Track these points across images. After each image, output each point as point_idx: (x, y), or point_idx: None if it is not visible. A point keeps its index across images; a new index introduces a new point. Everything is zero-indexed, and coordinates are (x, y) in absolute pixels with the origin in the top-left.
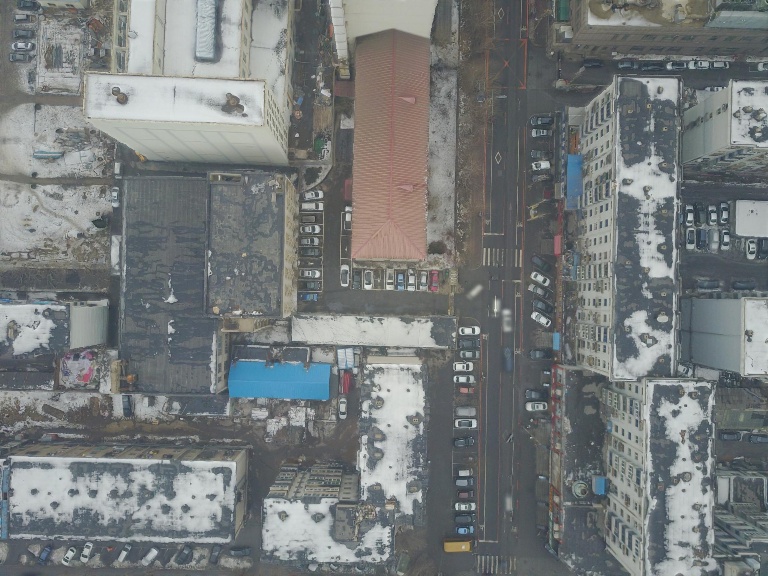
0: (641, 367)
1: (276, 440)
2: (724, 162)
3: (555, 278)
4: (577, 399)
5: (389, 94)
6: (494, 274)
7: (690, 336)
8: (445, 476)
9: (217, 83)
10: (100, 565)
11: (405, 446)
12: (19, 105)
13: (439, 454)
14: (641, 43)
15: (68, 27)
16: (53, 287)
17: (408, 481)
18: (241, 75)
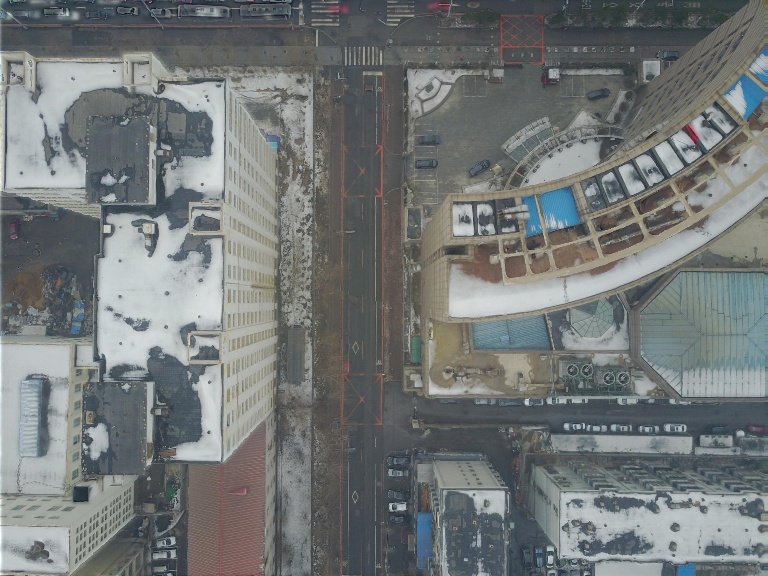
0: None
1: None
2: None
3: None
4: None
5: (218, 491)
6: None
7: None
8: None
9: (21, 529)
10: None
11: None
12: None
13: None
14: None
15: None
16: None
17: None
18: (69, 468)
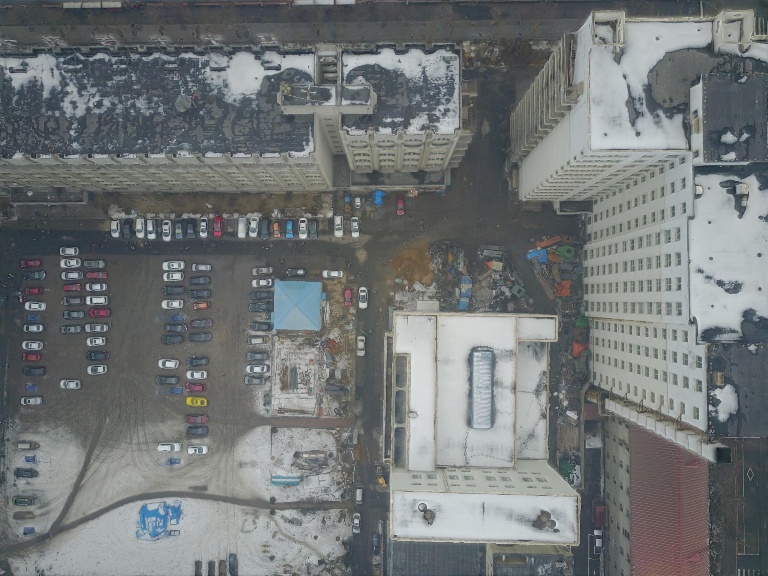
0: None
1: None
2: None
3: None
4: None
5: (675, 464)
6: None
7: None
8: None
9: (527, 498)
10: None
11: None
12: (255, 428)
13: None
14: None
15: (302, 347)
16: None
17: None
18: None
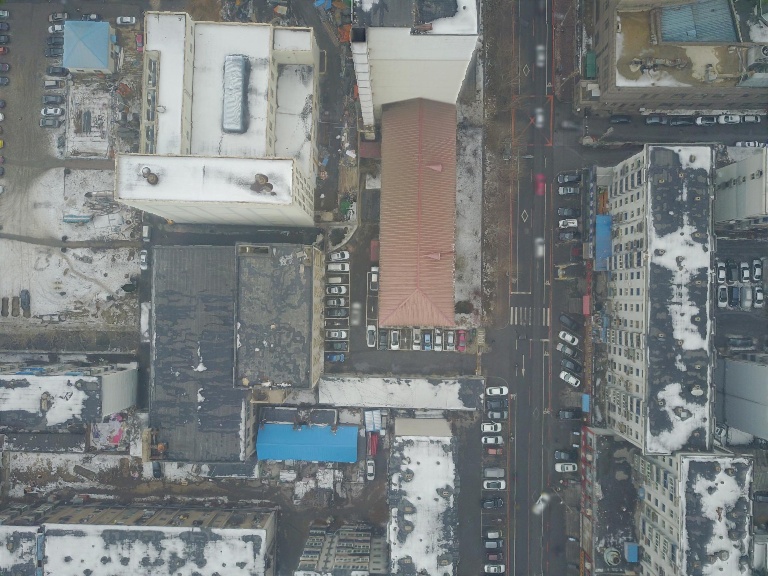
0: (675, 441)
1: (304, 503)
2: (758, 224)
3: (584, 337)
4: (608, 465)
5: (416, 163)
6: (522, 333)
7: (723, 398)
8: (474, 538)
9: (246, 162)
10: None
11: (435, 519)
12: (49, 169)
13: (468, 515)
14: (670, 100)
15: (96, 92)
16: (83, 349)
17: (439, 554)
18: (268, 145)
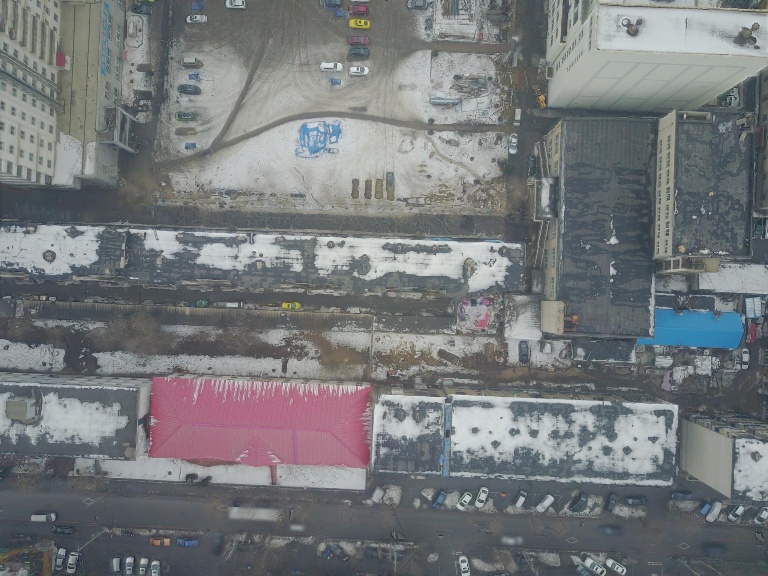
0: None
1: (686, 388)
2: None
3: None
4: None
5: None
6: None
7: None
8: None
9: (729, 15)
10: (494, 510)
11: None
12: (415, 52)
13: None
14: None
15: None
16: (448, 233)
17: None
18: None
